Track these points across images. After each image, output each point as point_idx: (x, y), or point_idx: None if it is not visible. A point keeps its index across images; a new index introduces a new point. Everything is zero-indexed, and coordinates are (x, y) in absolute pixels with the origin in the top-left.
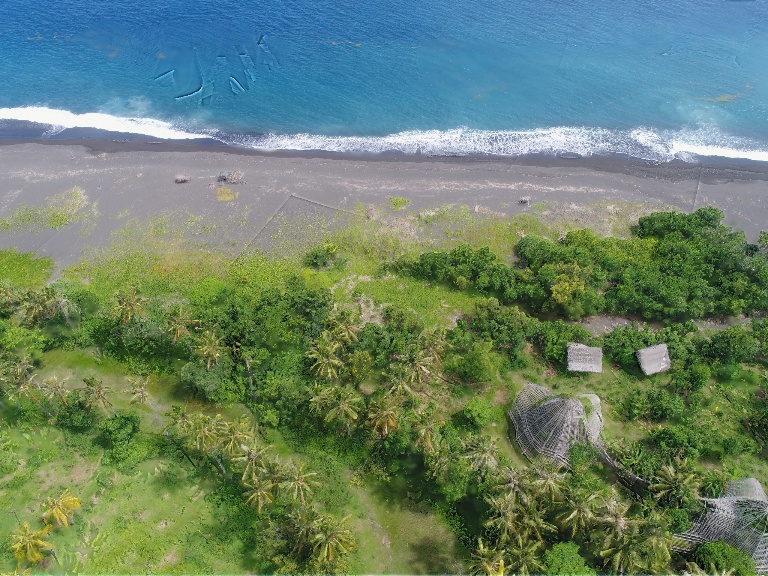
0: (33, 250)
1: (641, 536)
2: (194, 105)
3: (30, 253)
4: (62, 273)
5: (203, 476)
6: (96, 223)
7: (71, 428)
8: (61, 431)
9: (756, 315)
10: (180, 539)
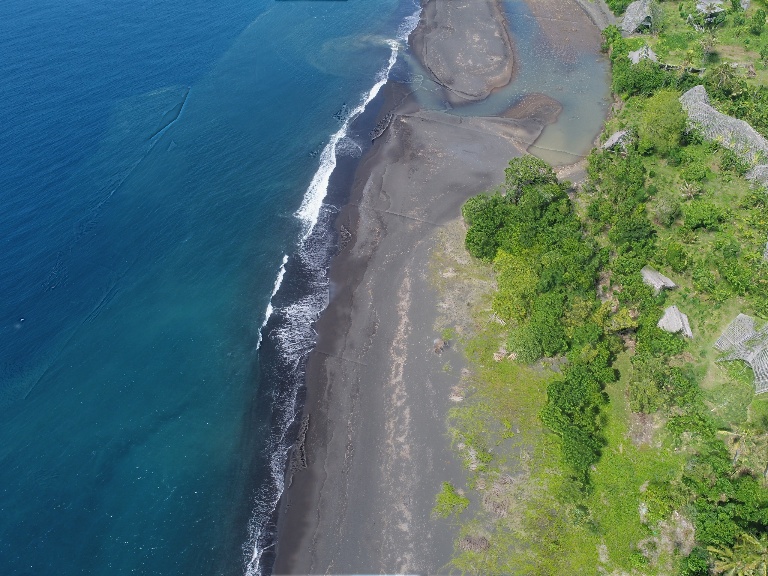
0: None
1: None
2: None
3: None
4: None
5: None
6: None
7: None
8: None
9: None
10: None
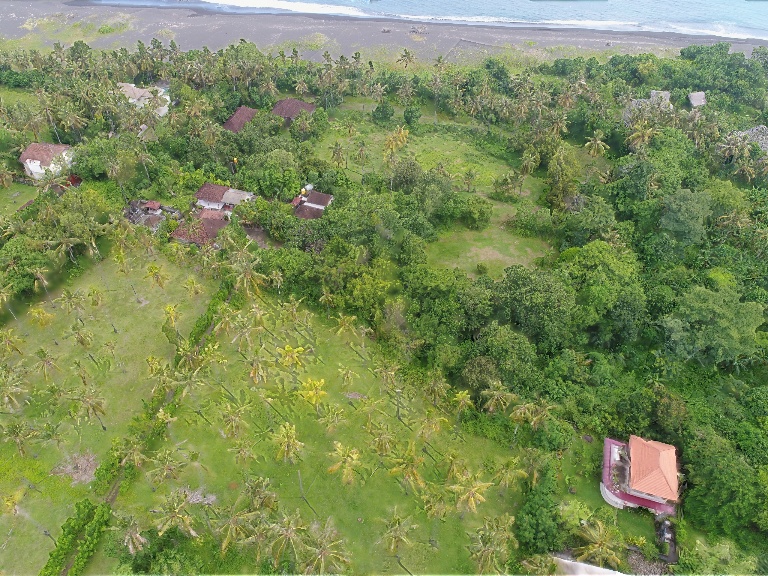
0: (306, 59)
1: (707, 121)
2: (364, 4)
3: (305, 60)
4: None
5: (462, 137)
6: (340, 48)
7: (379, 120)
8: (372, 123)
9: None
10: (461, 156)
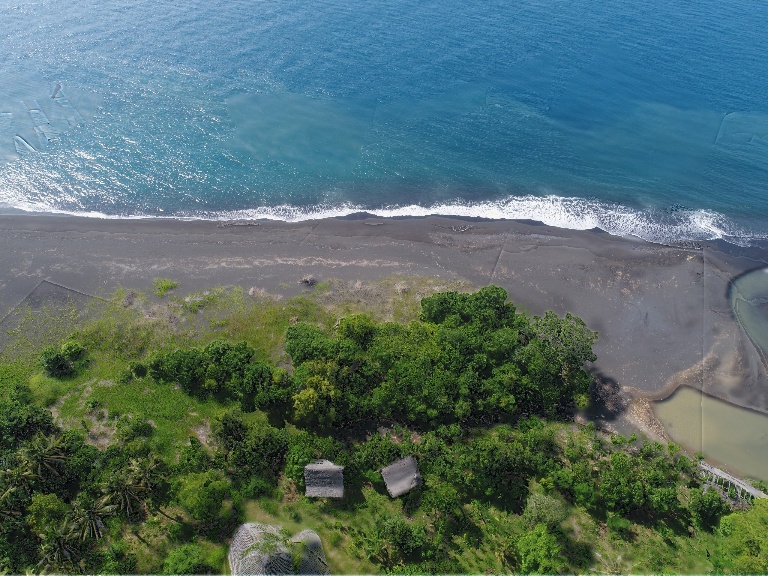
0: None
1: None
2: None
3: None
4: None
5: None
6: None
7: None
8: None
9: (534, 408)
10: None
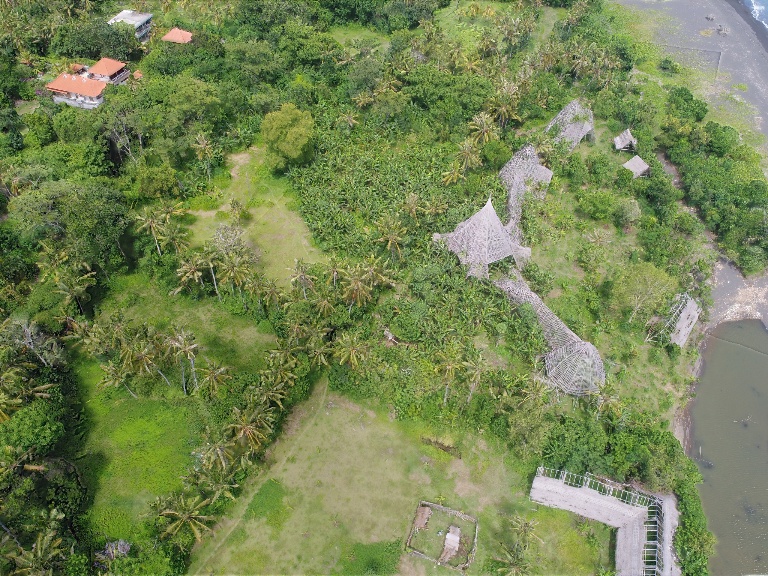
0: None
1: None
2: None
3: None
4: (613, 3)
5: None
6: (655, 3)
7: None
8: None
9: None
10: None
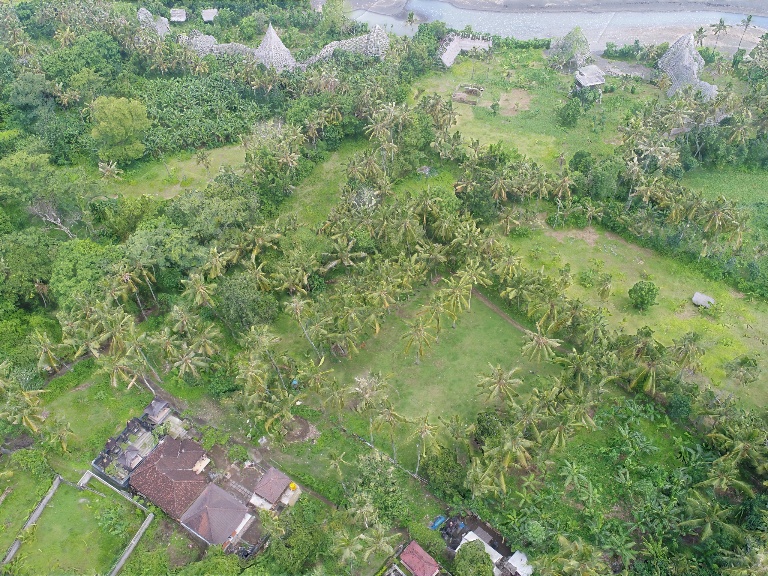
0: None
1: None
2: None
3: None
4: None
5: None
6: None
7: None
8: None
9: None
10: None
